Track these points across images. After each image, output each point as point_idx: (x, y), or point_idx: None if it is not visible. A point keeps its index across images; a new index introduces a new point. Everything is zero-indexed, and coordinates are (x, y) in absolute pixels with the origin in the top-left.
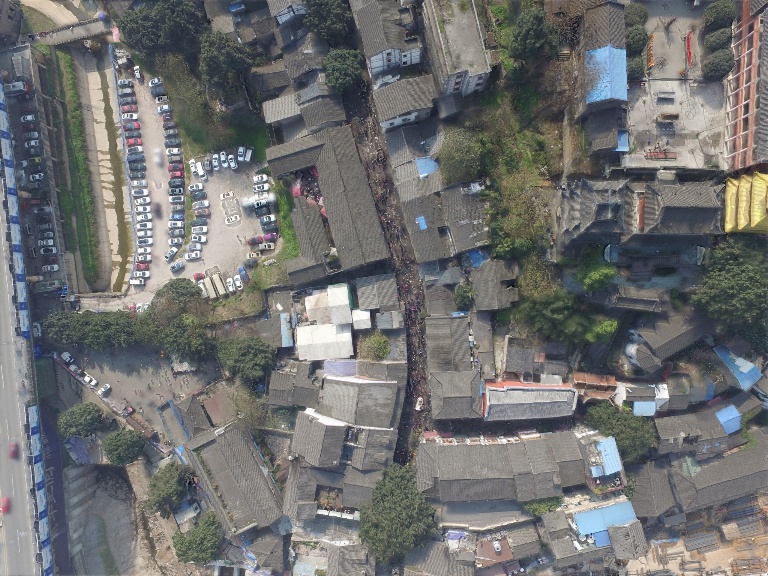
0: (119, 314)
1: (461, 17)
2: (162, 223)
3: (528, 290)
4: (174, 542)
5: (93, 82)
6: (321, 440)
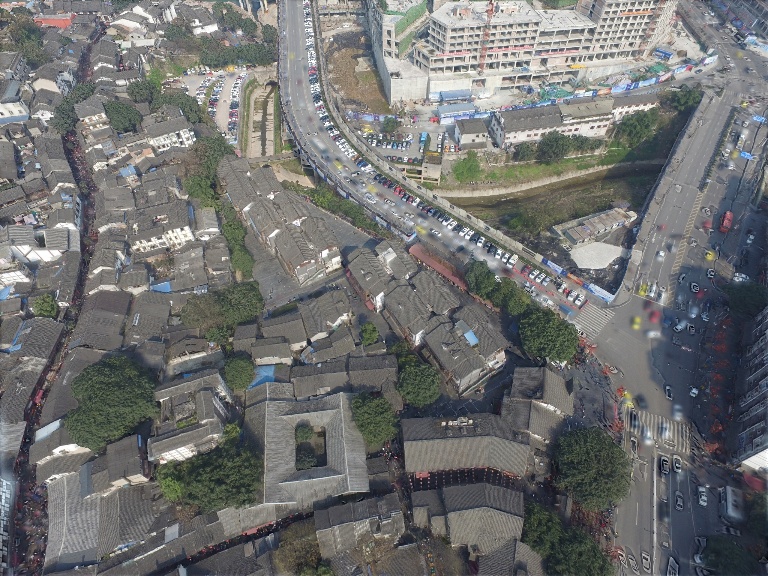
0: (242, 53)
1: (0, 66)
2: (226, 91)
3: (28, 16)
4: (230, 7)
5: (270, 154)
6: (141, 3)
